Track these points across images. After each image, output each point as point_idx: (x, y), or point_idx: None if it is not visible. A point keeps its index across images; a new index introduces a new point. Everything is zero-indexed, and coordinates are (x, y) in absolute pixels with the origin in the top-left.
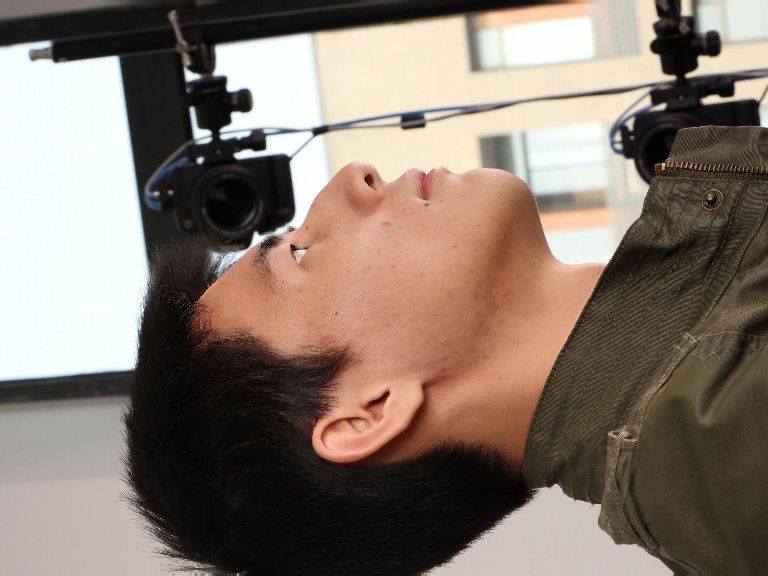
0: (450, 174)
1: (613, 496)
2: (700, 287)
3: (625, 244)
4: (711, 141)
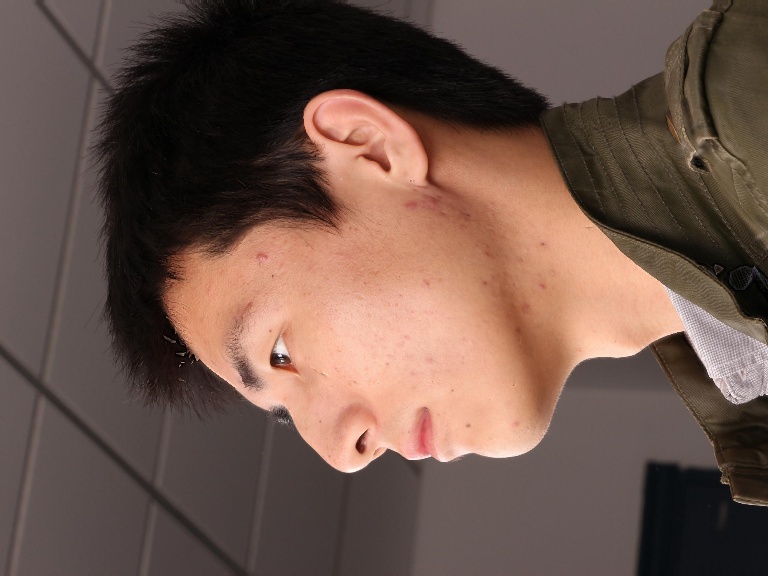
0: (456, 452)
1: None
2: None
3: None
4: None
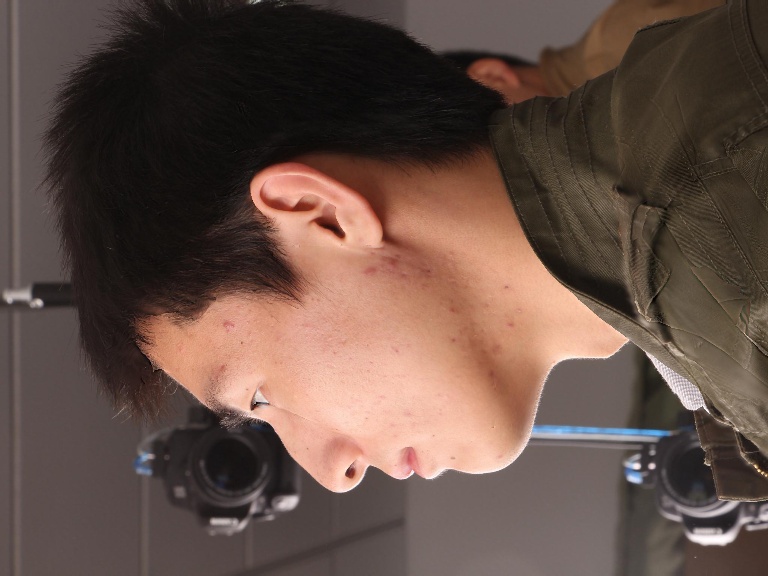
0: None
1: (762, 188)
2: (762, 336)
3: None
4: (759, 485)
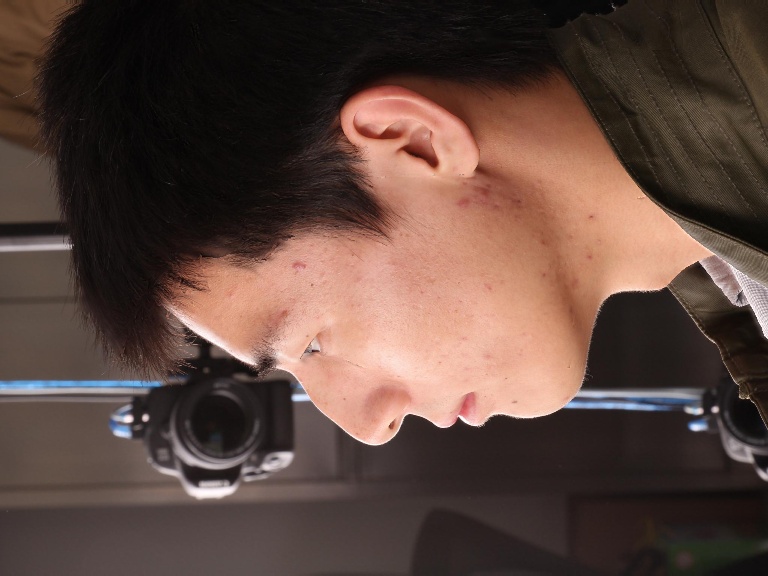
0: None
1: None
2: None
3: (699, 318)
4: None
